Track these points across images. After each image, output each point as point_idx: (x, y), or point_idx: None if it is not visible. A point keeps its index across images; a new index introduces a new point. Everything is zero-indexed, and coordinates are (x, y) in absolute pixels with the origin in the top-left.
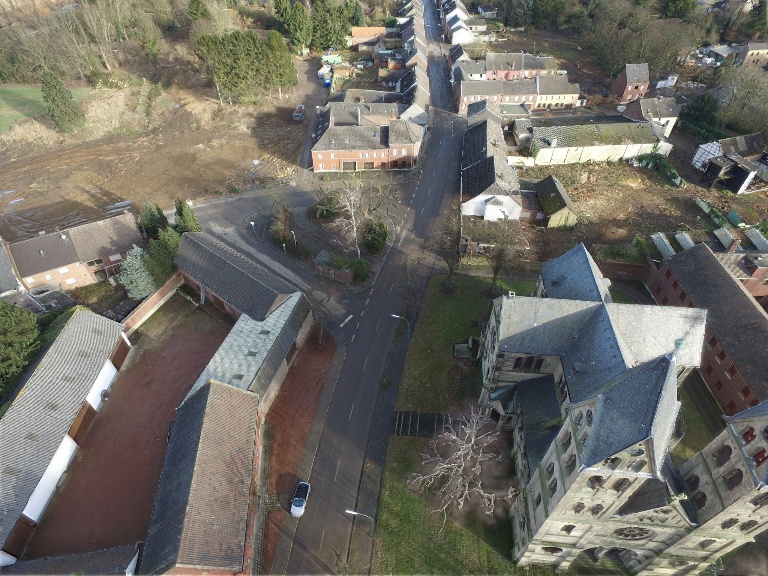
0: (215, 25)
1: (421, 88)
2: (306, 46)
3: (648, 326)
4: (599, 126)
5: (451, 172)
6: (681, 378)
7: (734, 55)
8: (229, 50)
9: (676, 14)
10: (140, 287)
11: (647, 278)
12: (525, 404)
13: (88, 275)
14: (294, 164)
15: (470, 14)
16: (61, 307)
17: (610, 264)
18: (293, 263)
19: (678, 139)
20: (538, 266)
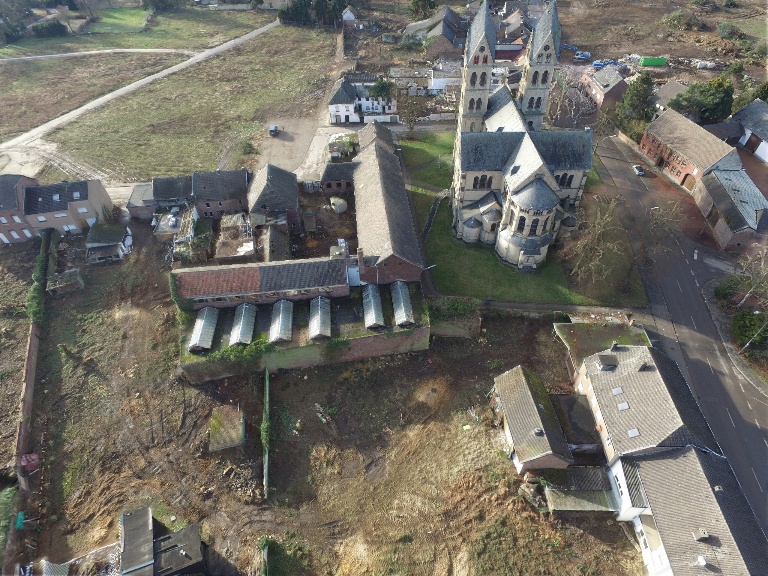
0: None
1: None
2: None
3: None
4: None
5: None
6: None
7: None
8: None
9: None
10: None
11: None
12: None
13: None
14: None
15: None
16: None
17: None
18: None
19: None
20: None
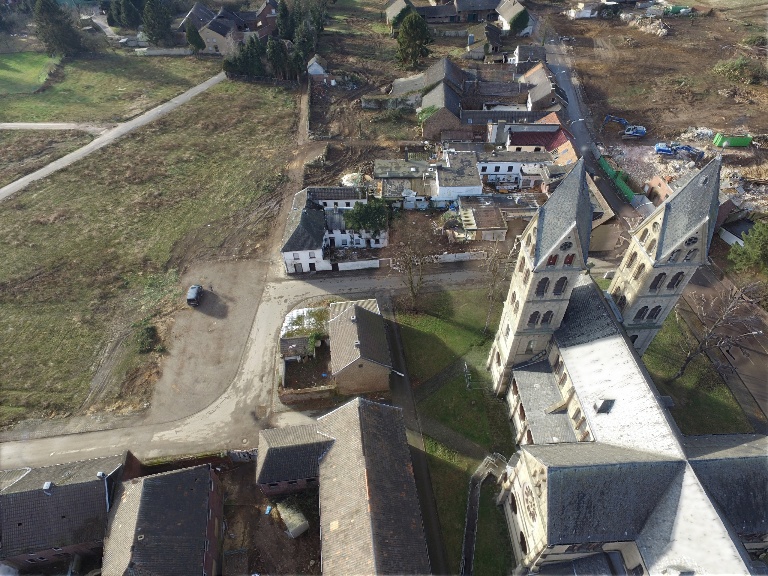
0: None
1: None
2: None
3: None
4: None
5: None
6: None
7: None
8: None
9: None
10: None
11: None
12: None
13: None
14: None
15: None
16: None
17: None
18: None
19: None
20: None
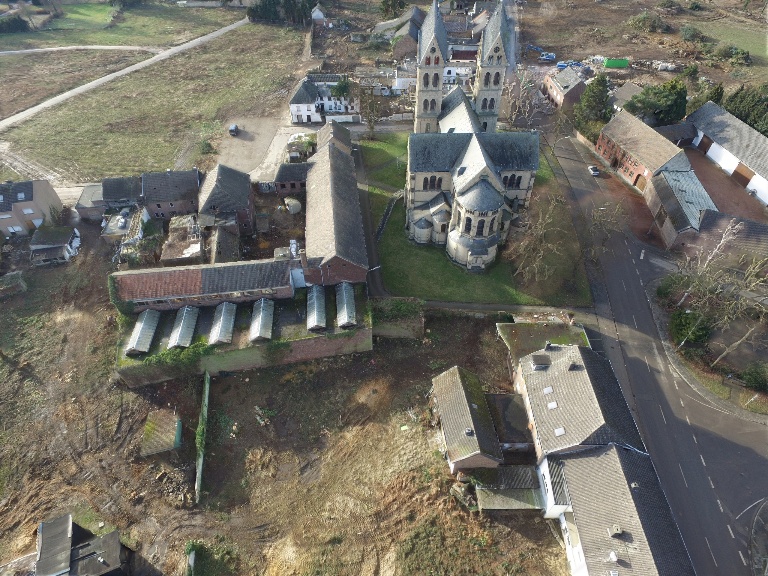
0: None
1: None
2: None
3: None
4: None
5: None
6: None
7: None
8: None
9: None
10: None
11: None
12: None
13: None
14: None
15: None
16: None
17: None
18: None
19: None
20: None
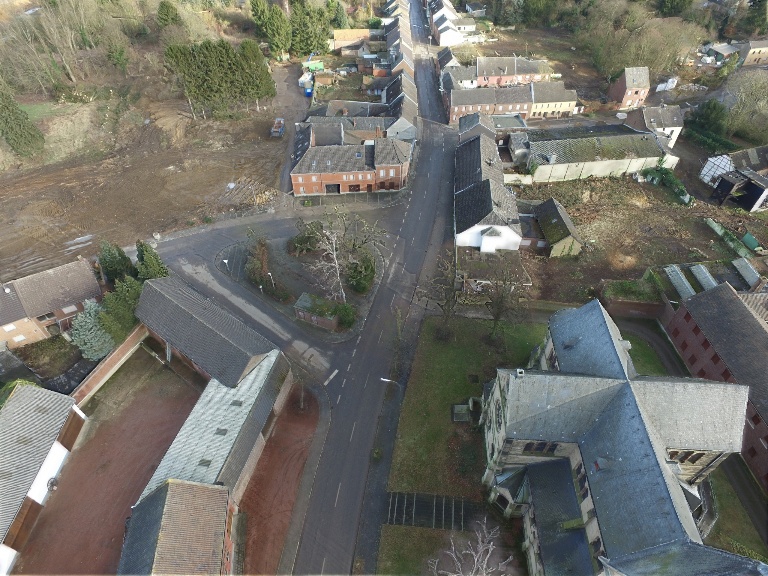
0: (187, 31)
1: (408, 99)
2: (286, 51)
3: (680, 407)
4: (600, 139)
5: (443, 193)
6: (717, 461)
7: (736, 55)
8: (200, 61)
9: (672, 10)
10: (96, 347)
11: (662, 317)
12: (538, 495)
13: (39, 330)
14: (273, 187)
15: (458, 13)
16: (6, 373)
17: (621, 303)
18: (271, 307)
19: (683, 149)
20: (542, 305)
